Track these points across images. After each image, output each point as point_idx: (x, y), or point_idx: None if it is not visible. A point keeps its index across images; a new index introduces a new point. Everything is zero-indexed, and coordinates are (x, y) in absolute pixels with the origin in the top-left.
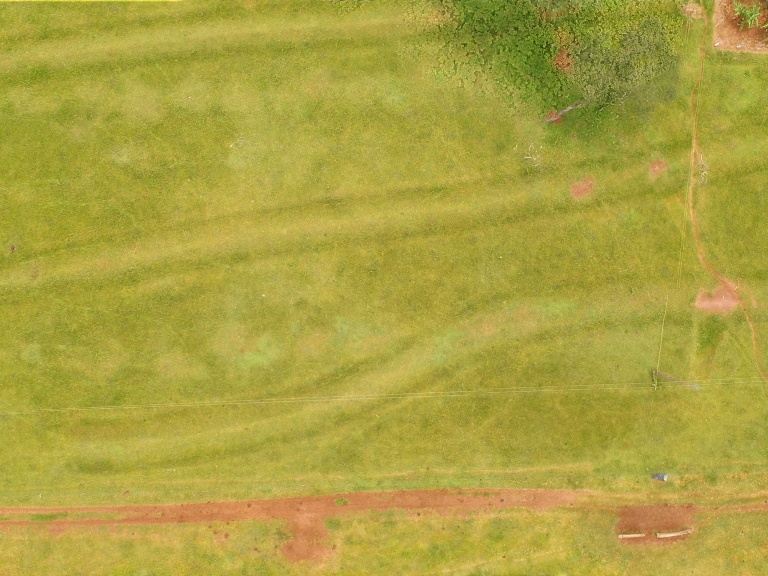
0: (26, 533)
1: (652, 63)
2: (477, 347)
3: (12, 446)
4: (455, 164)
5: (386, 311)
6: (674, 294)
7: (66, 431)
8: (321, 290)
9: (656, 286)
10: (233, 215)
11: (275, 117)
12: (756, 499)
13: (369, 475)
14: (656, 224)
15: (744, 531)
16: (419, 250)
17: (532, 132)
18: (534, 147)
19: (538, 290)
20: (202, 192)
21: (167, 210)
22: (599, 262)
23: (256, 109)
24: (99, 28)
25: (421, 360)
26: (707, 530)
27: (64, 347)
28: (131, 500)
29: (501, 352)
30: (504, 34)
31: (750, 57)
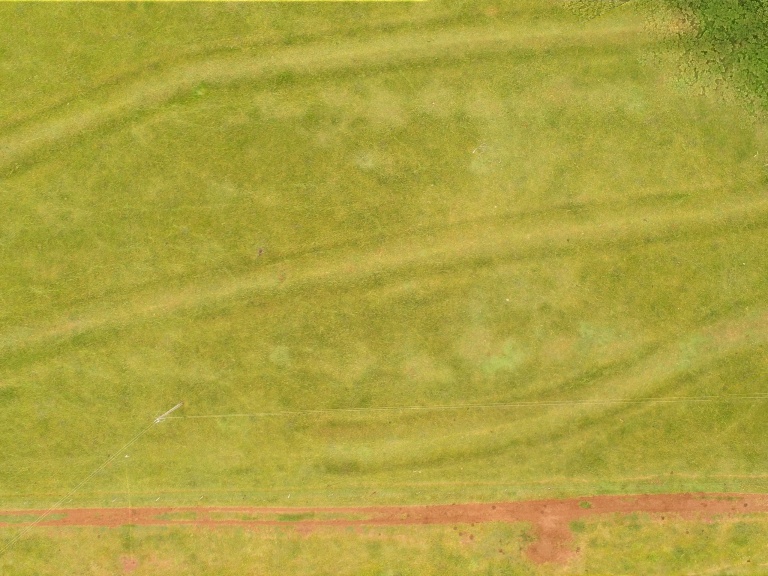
0: (274, 533)
1: None
2: (721, 353)
3: (260, 447)
4: (696, 171)
5: (629, 316)
6: None
7: (313, 432)
8: (565, 295)
9: None
10: (476, 220)
11: (517, 123)
12: None
13: (613, 479)
14: None
15: None
16: (661, 256)
17: None
18: None
19: None
20: (446, 197)
21: (411, 215)
22: None
23: (499, 115)
24: (342, 34)
25: (666, 365)
26: None
27: (311, 349)
28: (377, 501)
29: (745, 358)
30: (744, 42)
31: None
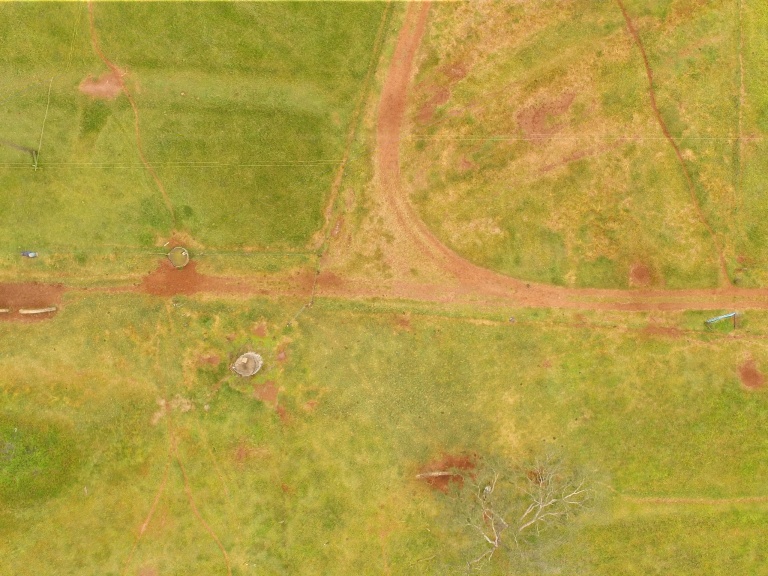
0: None
1: None
2: None
3: None
4: None
5: None
6: (60, 77)
7: None
8: None
9: (45, 69)
10: None
11: None
12: (124, 281)
13: None
14: (52, 9)
15: (110, 312)
16: None
17: None
18: None
19: None
20: None
21: None
22: None
23: None
24: None
25: None
26: (73, 309)
27: None
28: None
29: None
30: None
31: None
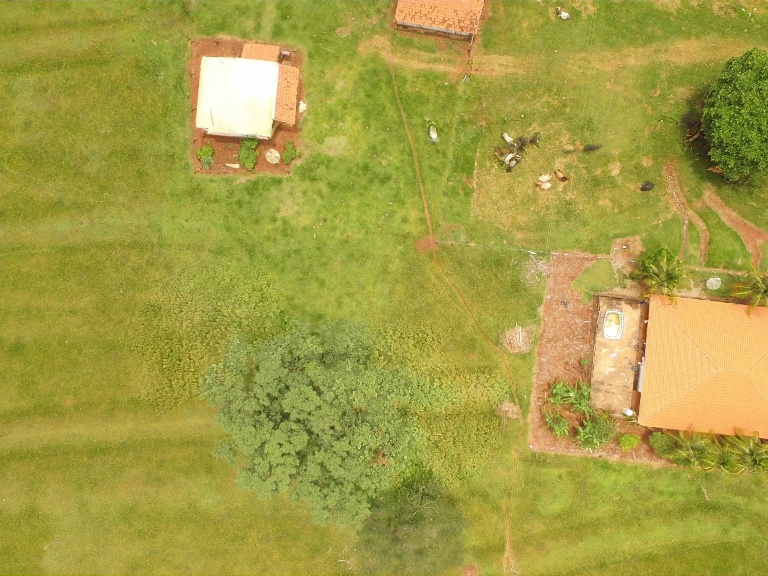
0: None
1: (466, 466)
2: None
3: None
4: (268, 568)
5: None
6: None
7: None
8: None
9: None
10: None
11: (89, 519)
12: None
13: None
14: None
15: None
16: None
17: (346, 535)
18: (348, 550)
19: None
20: None
21: None
22: None
23: (70, 511)
24: None
25: None
26: None
27: None
28: None
29: None
30: (320, 434)
31: (564, 459)
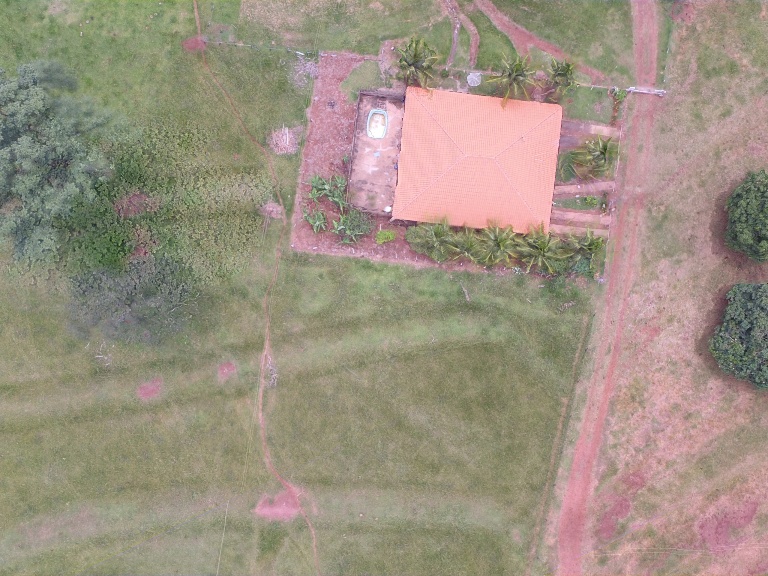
0: None
1: (226, 263)
2: (35, 550)
3: None
4: (25, 362)
5: None
6: (236, 499)
7: None
8: None
9: (219, 490)
10: None
11: None
12: None
13: None
14: (224, 427)
15: None
16: None
17: (104, 331)
18: (106, 346)
19: (102, 492)
20: None
21: None
22: (165, 464)
23: None
24: None
25: None
26: None
27: None
28: None
29: (59, 555)
30: (82, 230)
31: (326, 259)
